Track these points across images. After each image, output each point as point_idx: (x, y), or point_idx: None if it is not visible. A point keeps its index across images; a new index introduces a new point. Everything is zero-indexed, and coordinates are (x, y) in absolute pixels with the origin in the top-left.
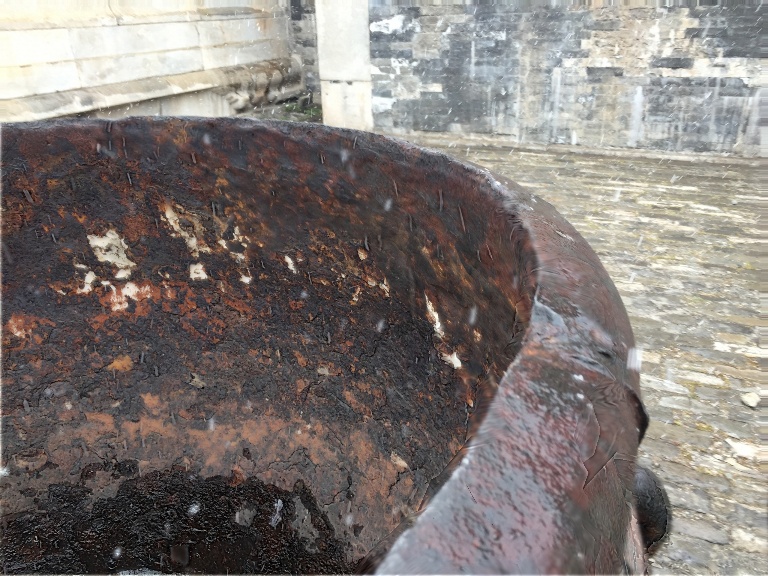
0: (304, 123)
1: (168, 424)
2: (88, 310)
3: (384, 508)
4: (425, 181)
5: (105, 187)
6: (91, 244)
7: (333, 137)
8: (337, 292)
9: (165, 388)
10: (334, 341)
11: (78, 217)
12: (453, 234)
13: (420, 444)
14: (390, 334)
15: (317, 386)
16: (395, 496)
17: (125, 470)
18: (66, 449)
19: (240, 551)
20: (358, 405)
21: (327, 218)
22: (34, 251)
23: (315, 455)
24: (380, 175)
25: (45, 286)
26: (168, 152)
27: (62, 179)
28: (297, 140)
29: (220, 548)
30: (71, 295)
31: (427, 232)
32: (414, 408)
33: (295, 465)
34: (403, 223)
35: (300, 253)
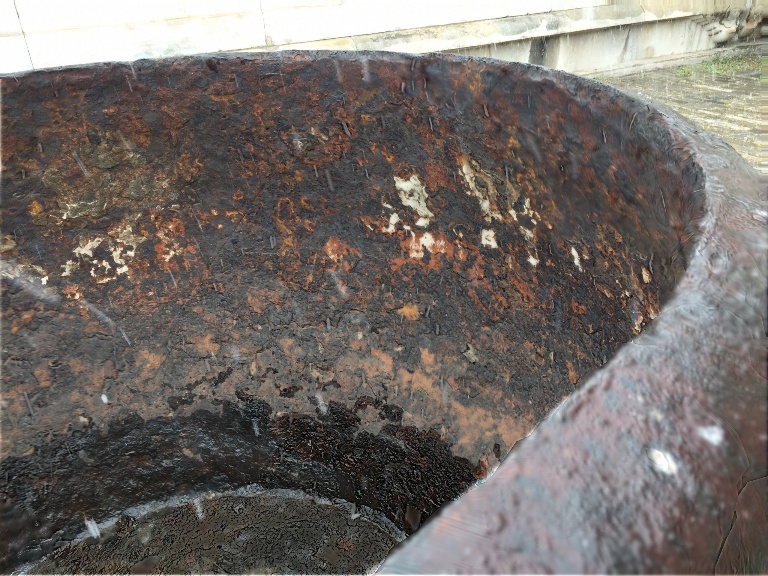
0: (594, 82)
1: (436, 386)
2: (390, 250)
3: None
4: (680, 207)
5: (410, 130)
6: (397, 186)
7: (614, 108)
8: (621, 311)
9: (441, 349)
10: None
11: (387, 157)
12: None
13: None
14: None
15: None
16: None
17: (391, 414)
18: (349, 374)
19: None
20: None
21: (614, 215)
22: (351, 183)
23: None
24: None
25: (358, 218)
26: (464, 100)
27: (374, 116)
28: (582, 105)
29: None
30: (378, 232)
31: None
32: None
33: None
34: None
35: (587, 249)
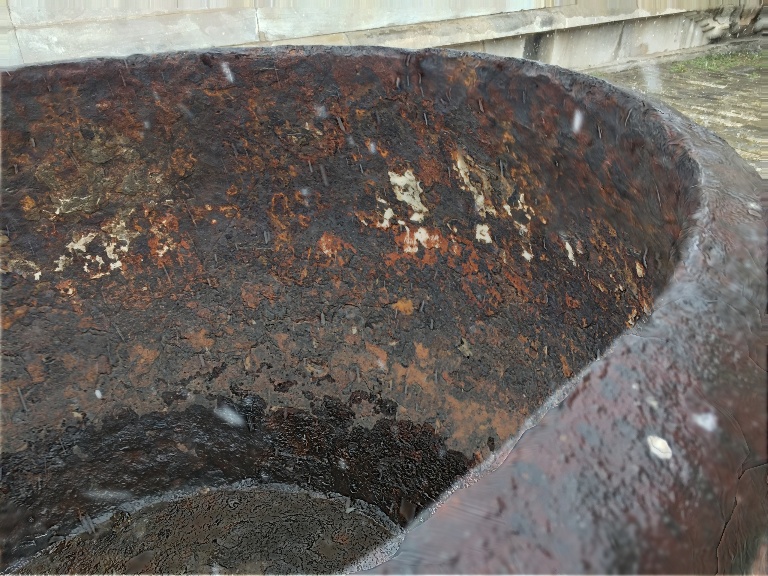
0: (589, 78)
1: (430, 380)
2: (385, 245)
3: None
4: (675, 202)
5: (405, 125)
6: (391, 181)
7: (610, 104)
8: (614, 305)
9: (436, 344)
10: None
11: (381, 152)
12: None
13: None
14: None
15: None
16: None
17: (385, 408)
18: (344, 369)
19: None
20: None
21: (609, 210)
22: (345, 178)
23: None
24: None
25: (352, 213)
26: (459, 95)
27: (369, 111)
28: (577, 101)
29: None
30: (372, 227)
31: None
32: None
33: None
34: None
35: (581, 244)
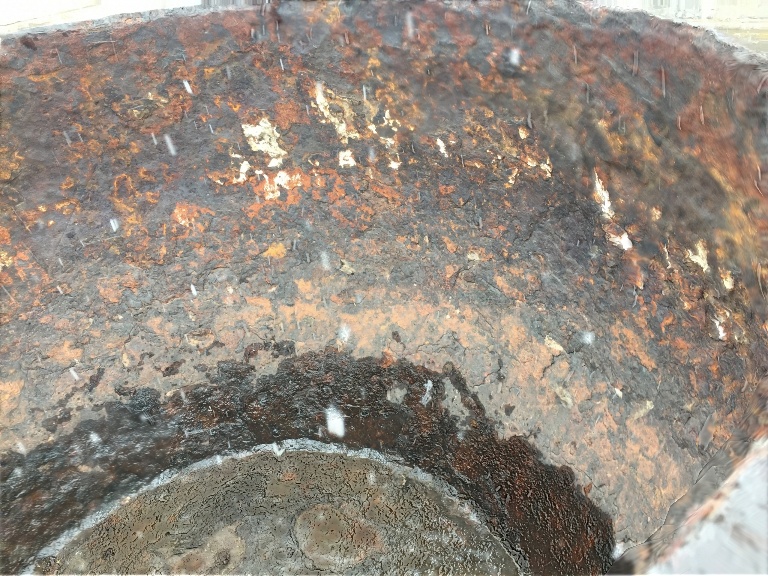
0: None
1: (320, 308)
2: (243, 199)
3: (537, 389)
4: (616, 43)
5: (258, 74)
6: (245, 134)
7: (502, 3)
8: (491, 175)
9: (316, 274)
10: (486, 226)
11: (233, 107)
12: (646, 101)
13: (578, 328)
14: (549, 217)
15: (467, 271)
16: (549, 378)
17: (283, 350)
18: (230, 330)
19: (392, 426)
20: (510, 290)
21: (486, 96)
22: (194, 142)
23: (464, 338)
24: (556, 42)
25: (204, 177)
26: (321, 34)
27: (218, 68)
28: (460, 10)
29: (373, 423)
30: (228, 185)
31: (608, 102)
32: (572, 292)
33: (444, 348)
34: (578, 95)
35: (453, 135)
